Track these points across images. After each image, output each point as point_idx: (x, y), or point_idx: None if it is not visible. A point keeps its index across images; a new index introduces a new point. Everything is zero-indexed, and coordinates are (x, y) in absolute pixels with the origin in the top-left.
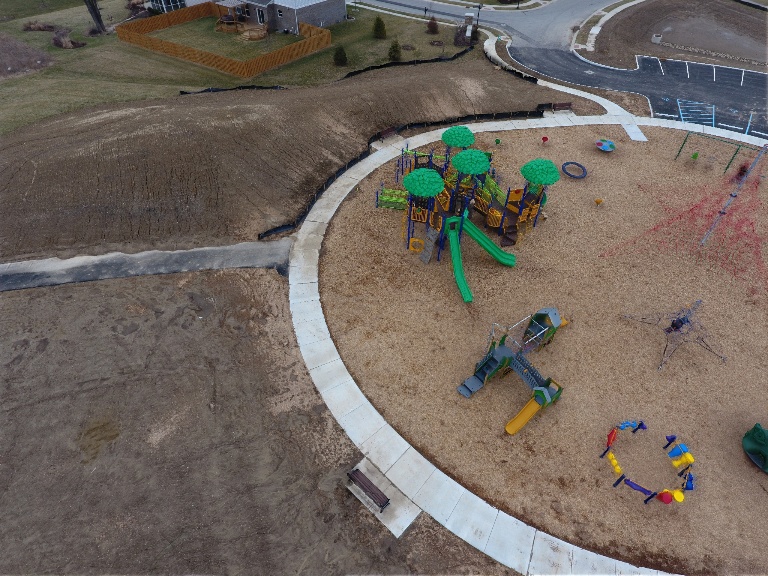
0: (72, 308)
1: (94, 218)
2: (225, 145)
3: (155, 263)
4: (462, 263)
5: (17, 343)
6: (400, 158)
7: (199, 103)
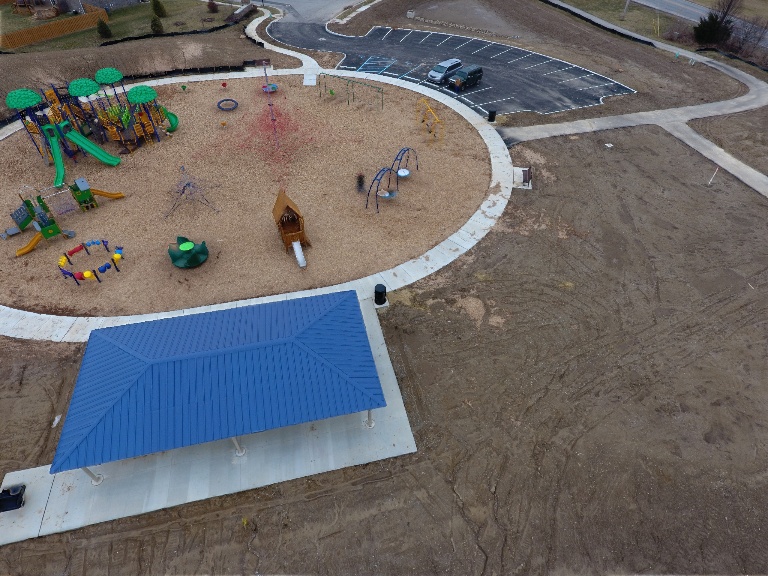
0: None
1: None
2: None
3: None
4: (79, 166)
5: None
6: (93, 101)
7: None
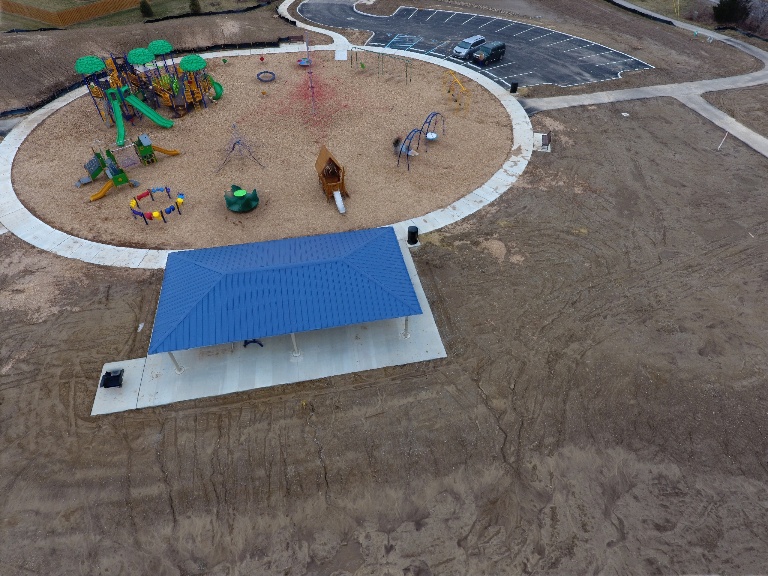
0: None
1: None
2: None
3: None
4: (136, 128)
5: None
6: None
7: None
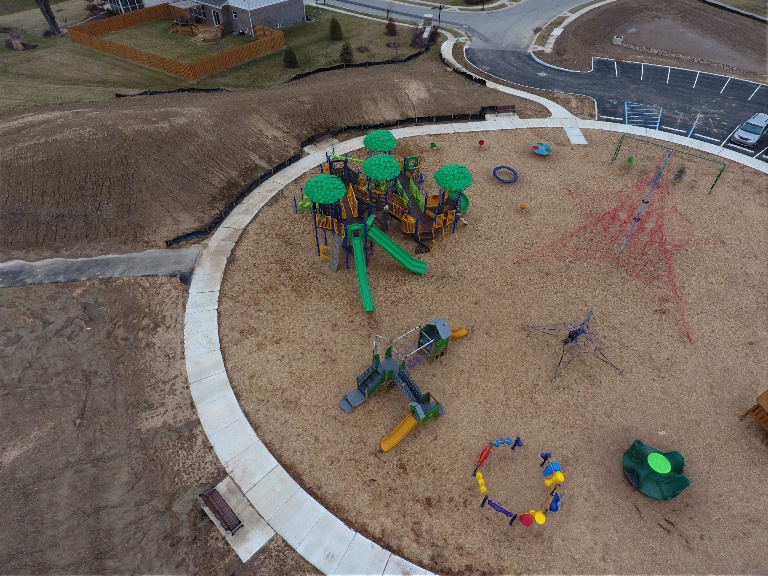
0: None
1: None
2: (146, 149)
3: (55, 271)
4: (372, 271)
5: None
6: None
7: (126, 106)
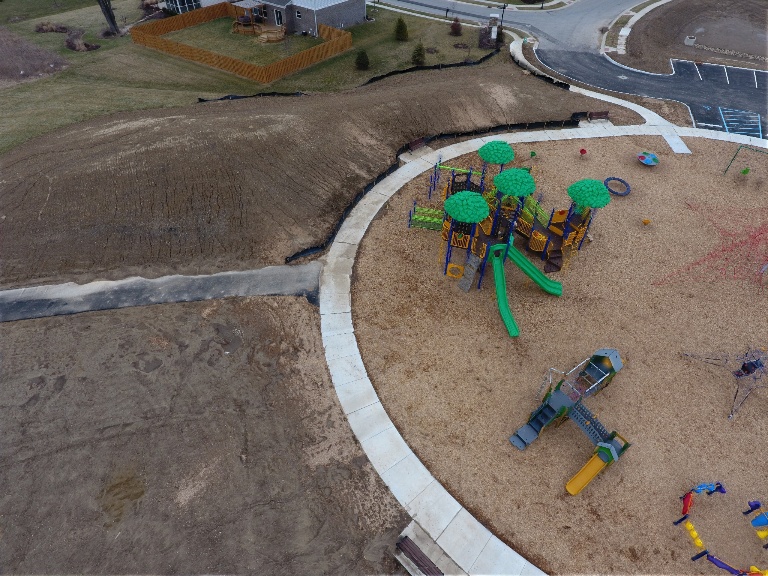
0: (90, 340)
1: (112, 239)
2: (248, 159)
3: (177, 289)
4: None
5: (33, 380)
6: (430, 172)
7: (220, 113)
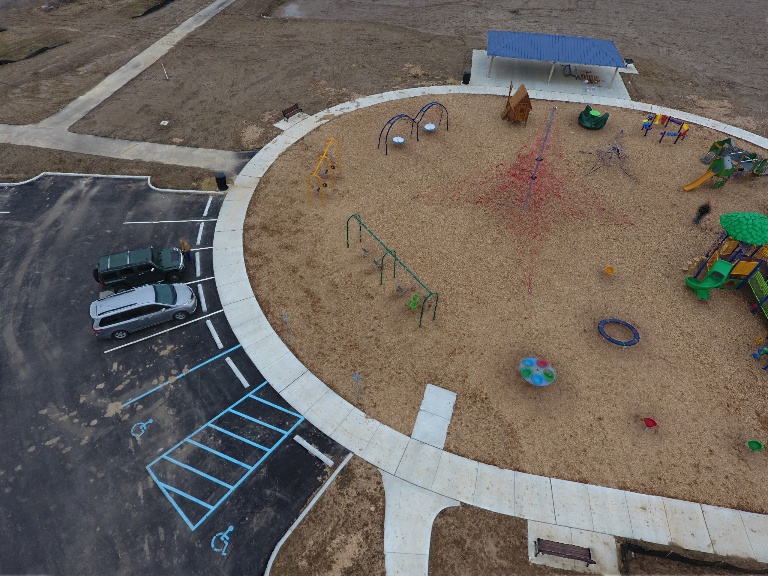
0: None
1: None
2: None
3: None
4: None
5: None
6: None
7: None
